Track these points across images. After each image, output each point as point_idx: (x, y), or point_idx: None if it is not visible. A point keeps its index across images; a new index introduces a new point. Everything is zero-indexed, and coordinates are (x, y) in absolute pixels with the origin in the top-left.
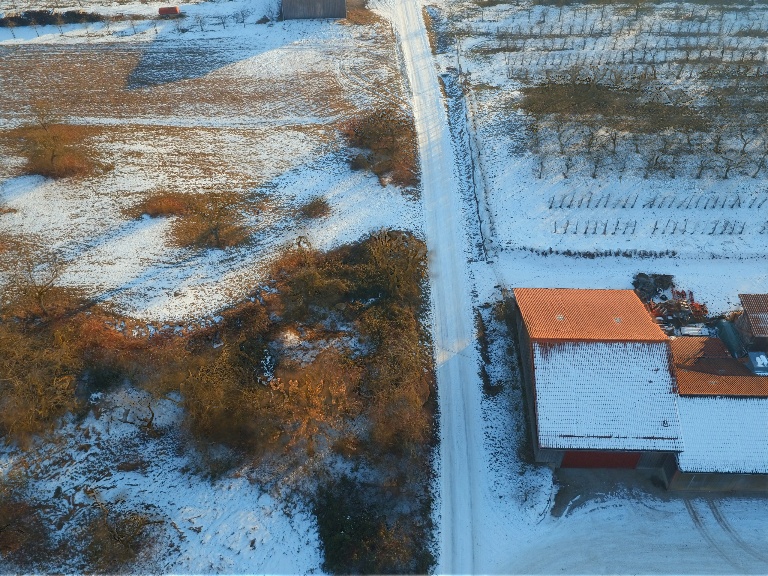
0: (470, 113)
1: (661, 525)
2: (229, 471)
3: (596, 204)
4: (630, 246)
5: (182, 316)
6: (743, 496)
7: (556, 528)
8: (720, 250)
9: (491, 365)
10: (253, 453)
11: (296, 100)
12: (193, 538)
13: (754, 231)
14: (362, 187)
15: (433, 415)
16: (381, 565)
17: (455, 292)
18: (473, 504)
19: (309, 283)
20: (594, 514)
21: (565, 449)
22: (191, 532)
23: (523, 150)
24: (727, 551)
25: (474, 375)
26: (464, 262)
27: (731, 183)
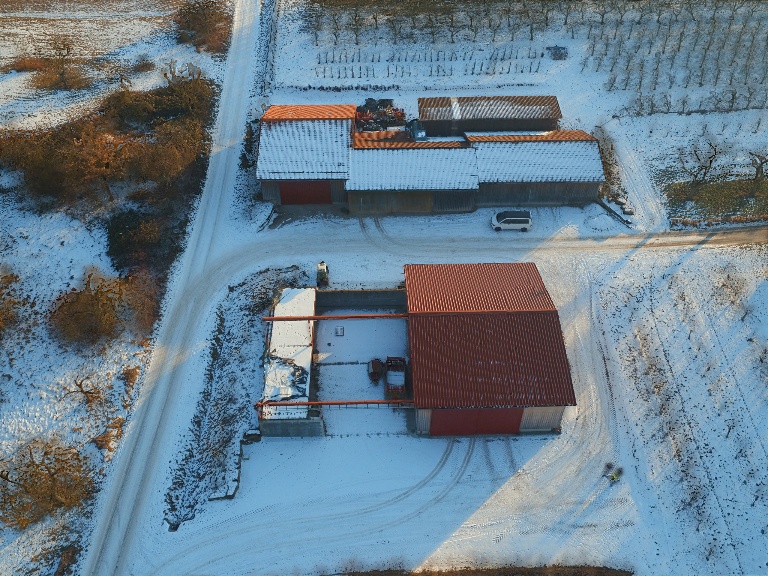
0: (277, 7)
1: (339, 231)
2: (53, 209)
3: (352, 59)
4: (368, 83)
5: (32, 127)
6: (398, 215)
7: (269, 234)
8: (431, 84)
9: (251, 154)
10: (71, 200)
11: (145, 1)
12: (22, 242)
13: (461, 73)
14: (182, 53)
15: (201, 179)
16: (138, 240)
17: (236, 114)
18: (217, 223)
19: (121, 100)
20: (297, 227)
21: (272, 180)
22: (21, 239)
23: (310, 29)
24: (377, 241)
25: (236, 158)
26: (247, 97)
27: (456, 46)
